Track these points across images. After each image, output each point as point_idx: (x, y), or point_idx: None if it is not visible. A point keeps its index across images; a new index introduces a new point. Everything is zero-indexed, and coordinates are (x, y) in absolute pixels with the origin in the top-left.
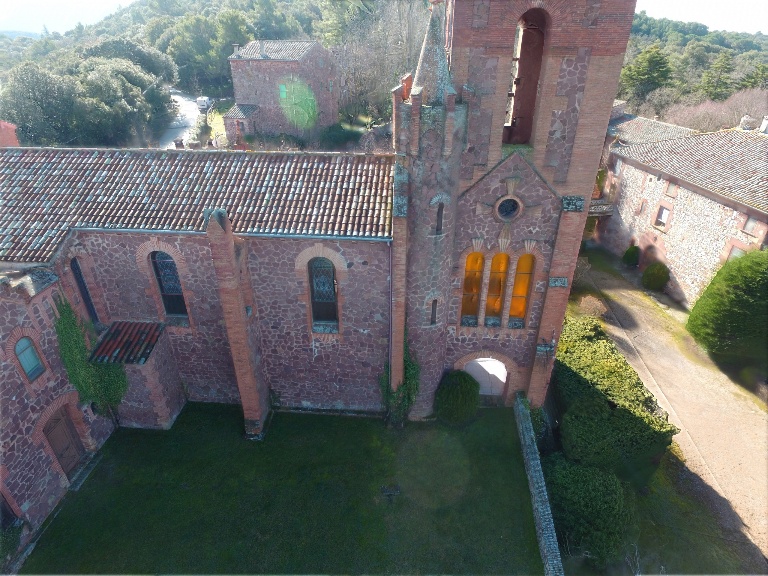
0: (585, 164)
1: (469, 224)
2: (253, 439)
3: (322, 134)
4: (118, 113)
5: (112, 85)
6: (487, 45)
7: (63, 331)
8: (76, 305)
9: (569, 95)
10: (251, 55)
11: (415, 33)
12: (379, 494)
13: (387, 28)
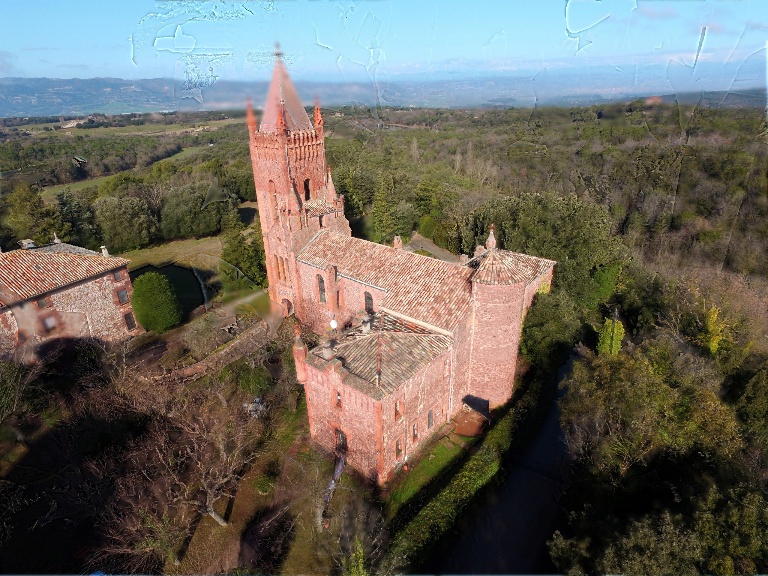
0: None
1: None
2: None
3: None
4: None
5: None
6: None
7: None
8: None
9: None
10: None
11: None
12: None
13: None
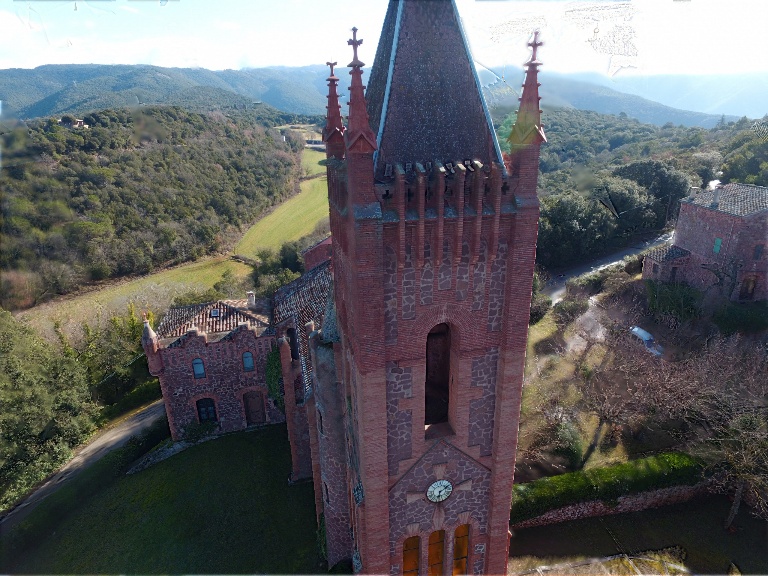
0: None
1: None
2: (288, 480)
3: (720, 308)
4: (558, 231)
5: (577, 207)
6: None
7: (271, 359)
8: None
9: None
10: (704, 200)
11: None
12: (260, 573)
13: None
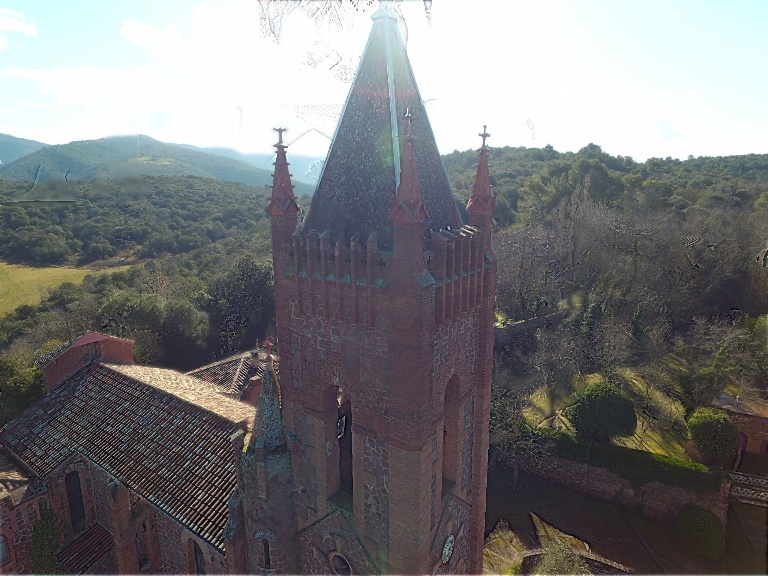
0: (404, 554)
1: (311, 563)
2: None
3: None
4: None
5: None
6: (304, 404)
7: (40, 530)
8: (60, 509)
9: (377, 474)
10: None
11: (582, 230)
12: None
13: (534, 233)
